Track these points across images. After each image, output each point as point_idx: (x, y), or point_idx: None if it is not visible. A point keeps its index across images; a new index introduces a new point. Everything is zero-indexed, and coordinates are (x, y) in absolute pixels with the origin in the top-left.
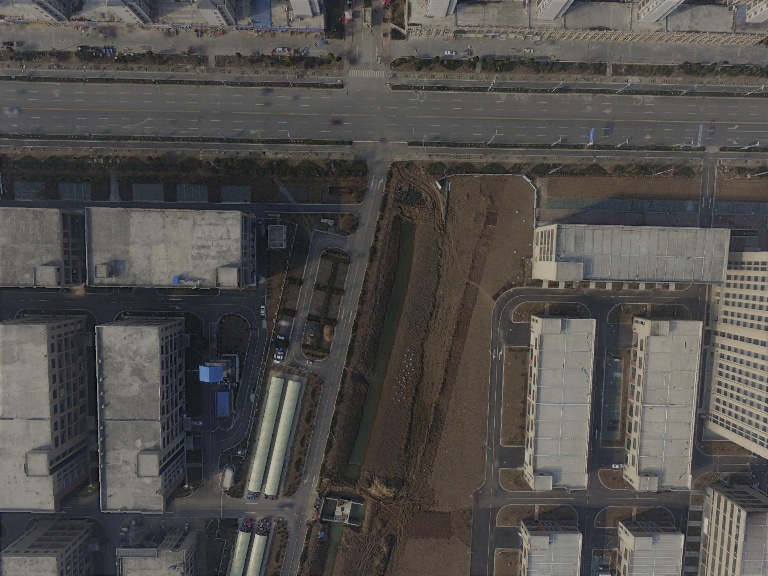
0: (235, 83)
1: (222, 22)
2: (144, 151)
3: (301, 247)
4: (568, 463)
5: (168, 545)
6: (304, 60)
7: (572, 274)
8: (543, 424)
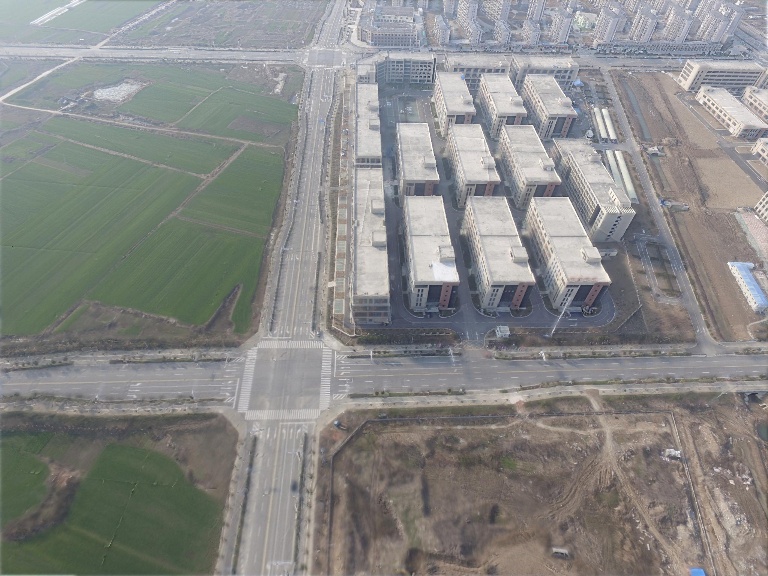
0: None
1: (535, 42)
2: None
3: None
4: (753, 122)
5: None
6: None
7: (705, 65)
8: (730, 112)
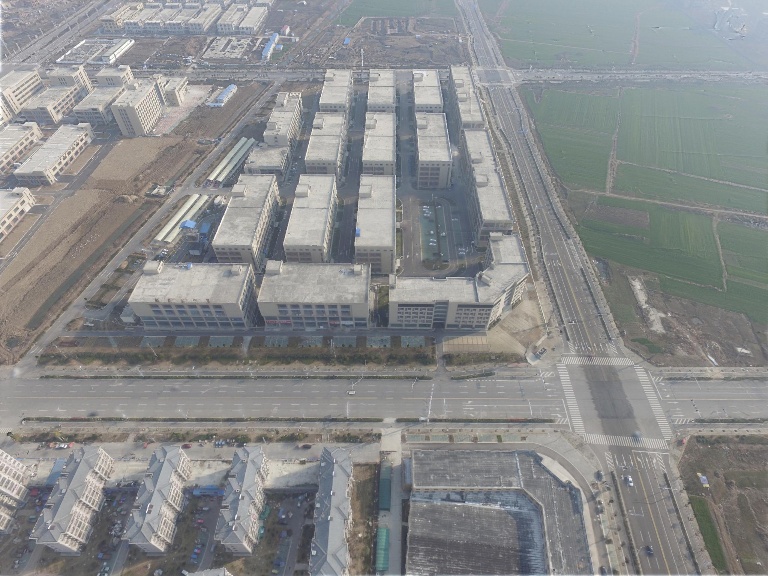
0: (118, 420)
1: None
2: (215, 369)
3: (118, 310)
4: None
5: (255, 171)
6: (46, 440)
7: None
8: (1, 215)
